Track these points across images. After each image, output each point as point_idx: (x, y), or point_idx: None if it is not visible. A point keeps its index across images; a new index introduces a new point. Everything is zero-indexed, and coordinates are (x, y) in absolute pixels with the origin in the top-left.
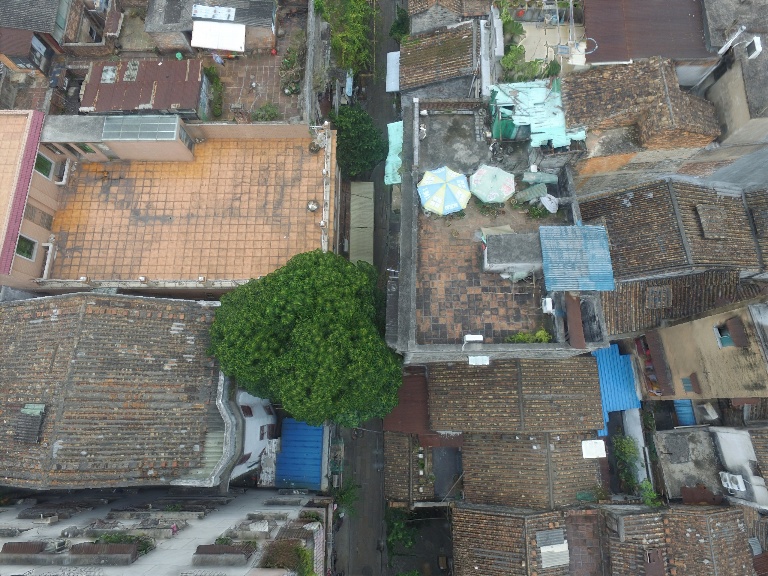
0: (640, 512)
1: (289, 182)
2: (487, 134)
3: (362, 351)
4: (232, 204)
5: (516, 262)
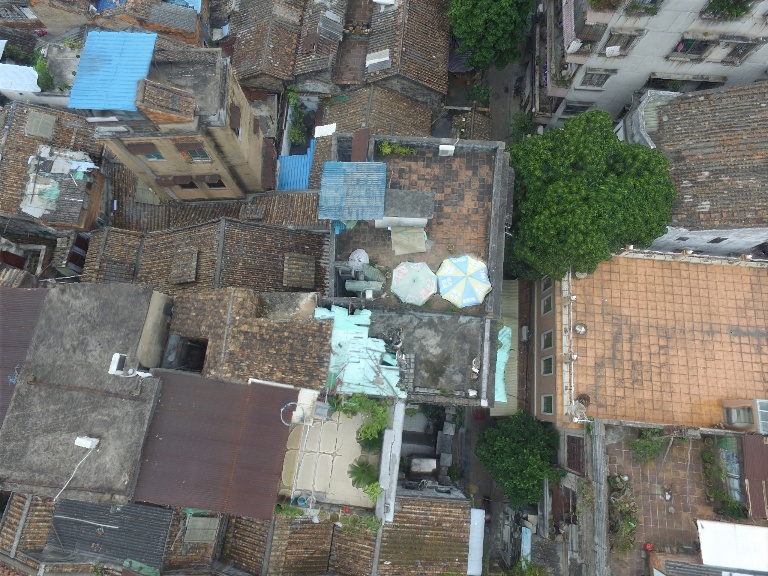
0: (310, 75)
1: (608, 362)
2: (404, 357)
3: (539, 158)
4: (667, 342)
5: (409, 191)
